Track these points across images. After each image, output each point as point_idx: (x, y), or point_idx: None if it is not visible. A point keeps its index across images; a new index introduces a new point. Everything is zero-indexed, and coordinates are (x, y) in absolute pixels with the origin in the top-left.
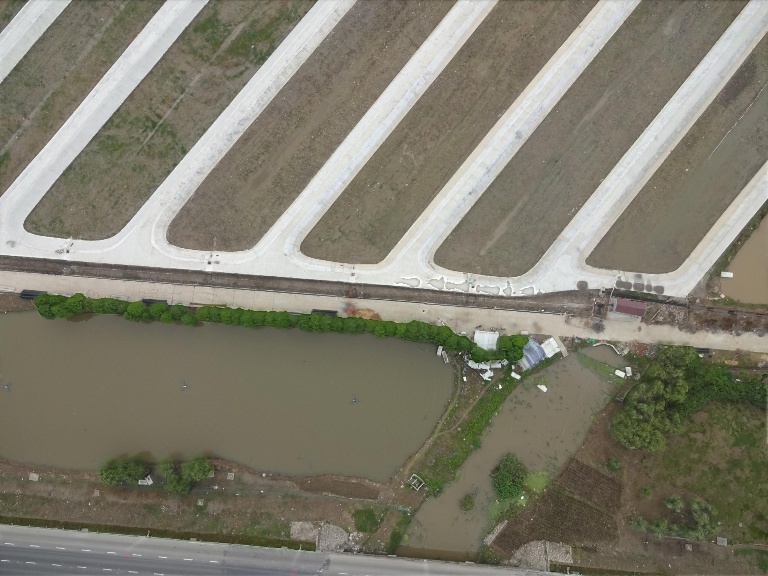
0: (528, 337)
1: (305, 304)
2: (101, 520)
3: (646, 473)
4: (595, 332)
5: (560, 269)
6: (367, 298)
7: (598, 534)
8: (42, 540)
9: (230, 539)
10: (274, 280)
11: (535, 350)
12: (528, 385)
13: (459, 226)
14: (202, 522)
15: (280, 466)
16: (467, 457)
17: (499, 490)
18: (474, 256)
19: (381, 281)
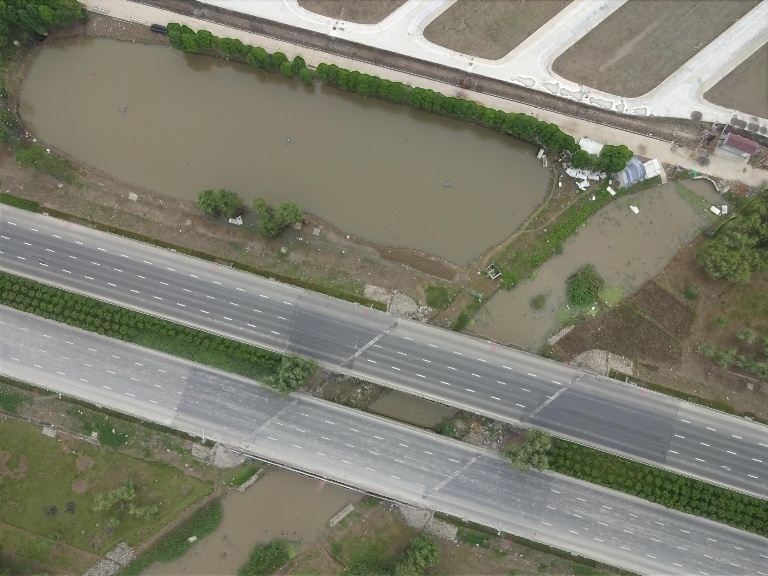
0: (631, 157)
1: (418, 86)
2: (189, 245)
3: (722, 308)
4: (699, 165)
5: (677, 96)
6: (479, 91)
7: (662, 355)
8: (132, 252)
9: (307, 285)
10: (393, 57)
11: (637, 167)
12: (621, 204)
13: (583, 39)
14: (282, 267)
15: (365, 232)
16: (547, 259)
17: (573, 295)
18: (592, 71)
19: (497, 75)
